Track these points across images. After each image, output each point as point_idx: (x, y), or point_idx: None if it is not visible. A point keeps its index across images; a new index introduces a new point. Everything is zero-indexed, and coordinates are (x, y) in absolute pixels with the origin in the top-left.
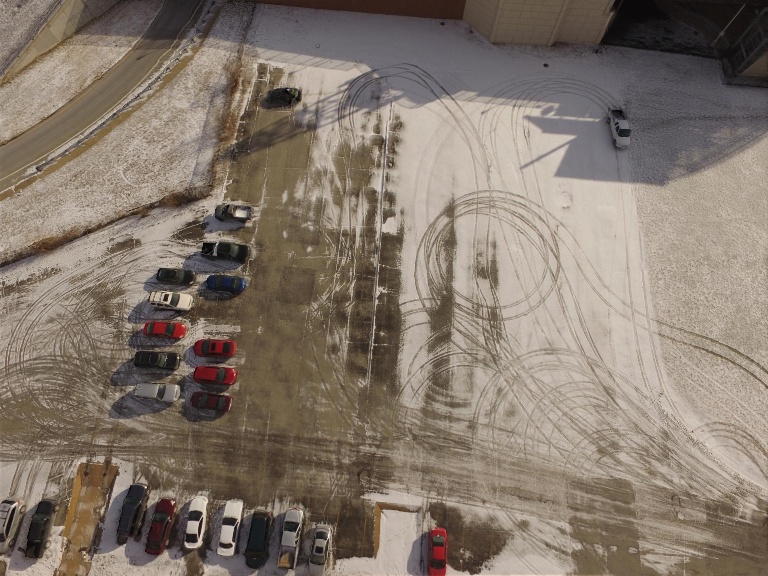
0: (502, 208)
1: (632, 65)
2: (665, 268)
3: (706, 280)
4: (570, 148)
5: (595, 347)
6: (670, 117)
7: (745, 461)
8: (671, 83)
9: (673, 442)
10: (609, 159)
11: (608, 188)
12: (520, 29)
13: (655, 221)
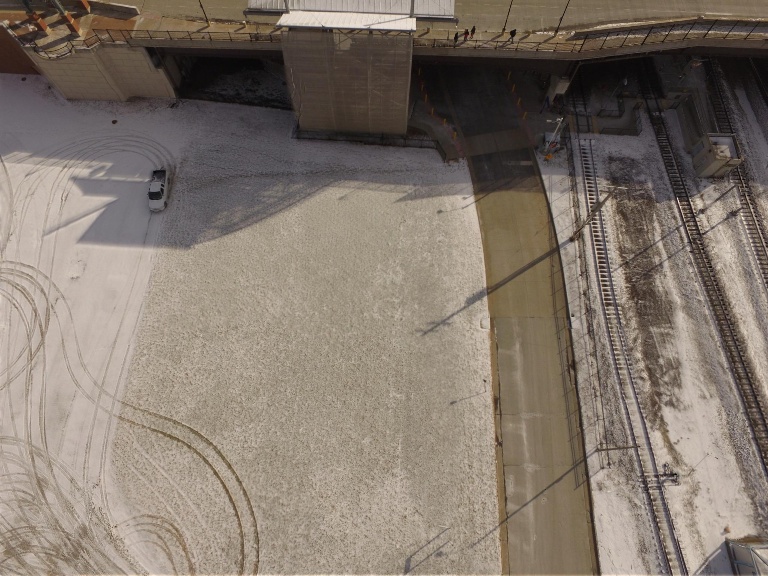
0: (6, 280)
1: (204, 120)
2: (154, 342)
3: (194, 354)
4: (104, 212)
5: (45, 434)
6: (224, 175)
7: (160, 558)
8: (237, 138)
9: (89, 539)
10: (140, 223)
11: (128, 255)
12: (79, 86)
13: (164, 290)
